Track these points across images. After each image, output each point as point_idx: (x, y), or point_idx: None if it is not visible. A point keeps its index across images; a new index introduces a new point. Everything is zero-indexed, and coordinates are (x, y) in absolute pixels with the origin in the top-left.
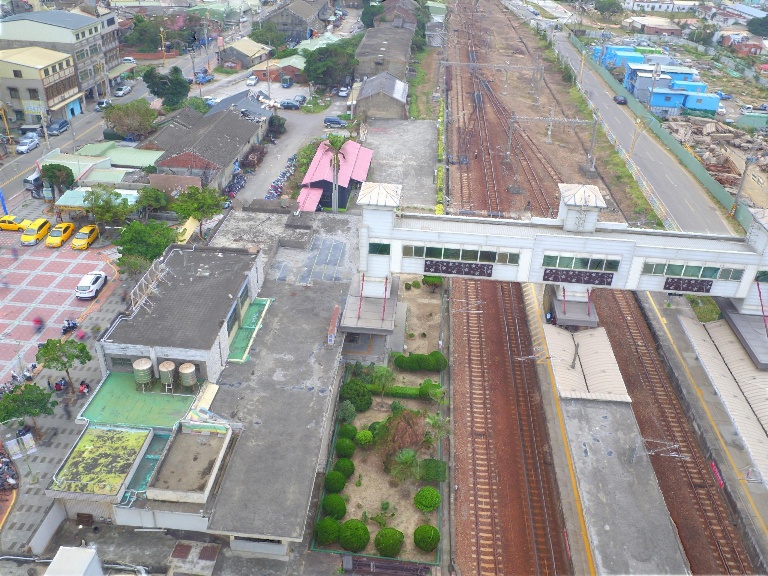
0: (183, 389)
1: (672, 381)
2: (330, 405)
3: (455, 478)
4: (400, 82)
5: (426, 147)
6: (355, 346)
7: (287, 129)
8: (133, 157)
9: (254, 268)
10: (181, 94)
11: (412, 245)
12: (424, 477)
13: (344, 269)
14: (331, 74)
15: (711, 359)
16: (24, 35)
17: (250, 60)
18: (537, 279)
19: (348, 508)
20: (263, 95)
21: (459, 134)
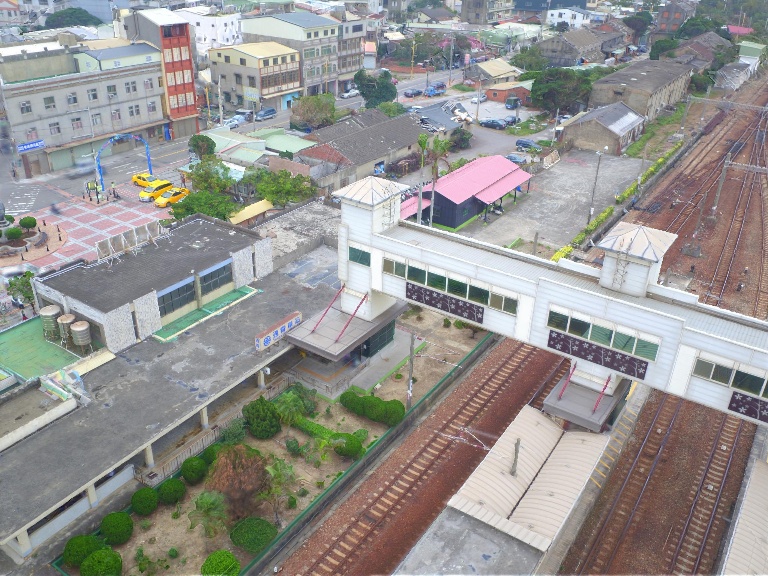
0: (78, 348)
1: (720, 558)
2: None
3: (289, 558)
4: (633, 115)
5: (615, 186)
6: (322, 367)
7: (473, 146)
8: (288, 144)
9: (246, 252)
10: (385, 98)
11: (393, 259)
12: (234, 538)
13: None
14: (554, 98)
15: (754, 542)
16: (268, 31)
17: (492, 80)
18: (541, 342)
19: (139, 537)
20: (460, 108)
21: (674, 180)
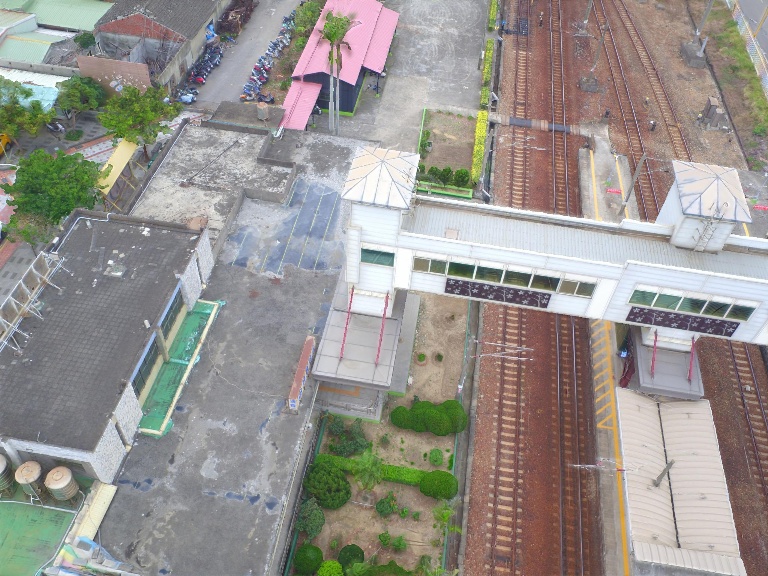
0: None
1: None
2: (288, 501)
3: None
4: None
5: (474, 3)
6: None
7: None
8: (68, 13)
9: (191, 263)
10: None
11: (428, 257)
12: None
13: (333, 246)
14: None
15: None
16: None
17: None
18: (617, 317)
19: None
20: None
21: None
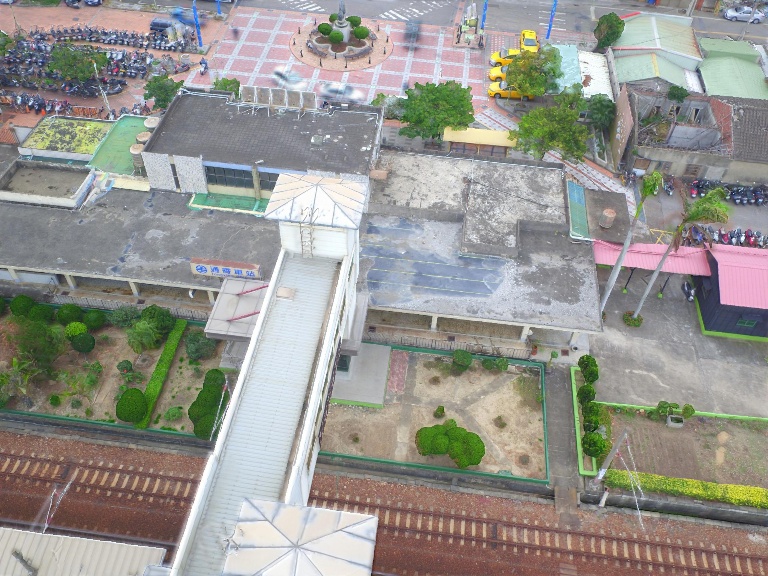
0: None
1: None
2: None
3: (2, 431)
4: None
5: None
6: None
7: None
8: (726, 79)
9: (326, 176)
10: None
11: None
12: None
13: (403, 293)
14: None
15: None
16: None
17: None
18: None
19: None
20: None
21: None
